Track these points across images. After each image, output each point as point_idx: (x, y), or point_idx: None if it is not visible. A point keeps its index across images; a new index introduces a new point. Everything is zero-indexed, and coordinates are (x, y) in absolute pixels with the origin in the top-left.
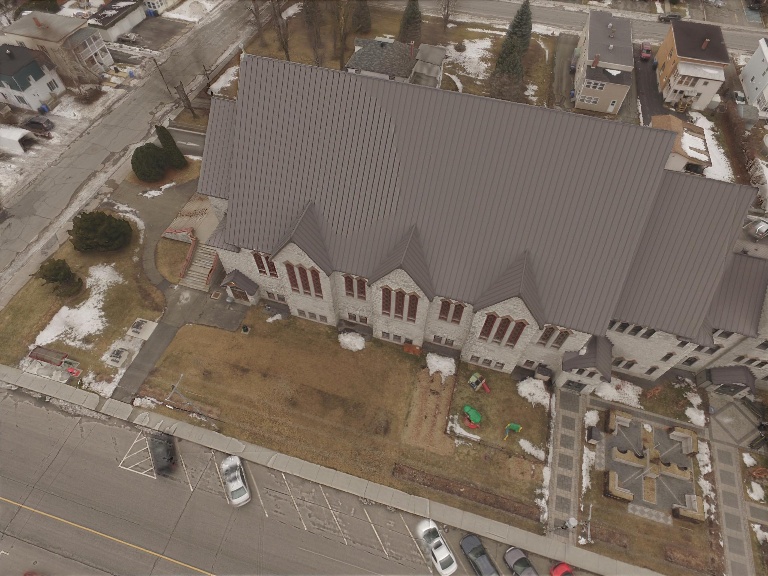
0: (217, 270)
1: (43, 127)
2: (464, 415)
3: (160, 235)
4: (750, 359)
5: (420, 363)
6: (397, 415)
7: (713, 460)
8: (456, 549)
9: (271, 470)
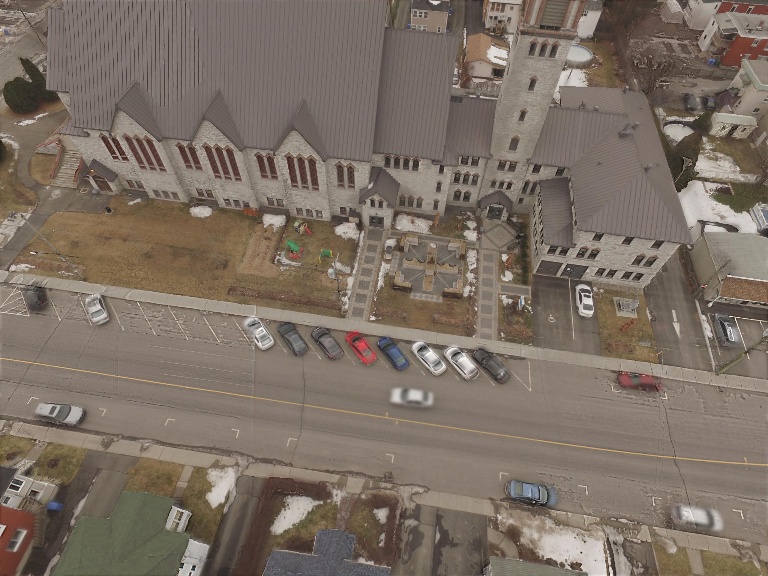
0: (84, 171)
1: None
2: (289, 250)
3: (33, 152)
4: (500, 183)
5: (257, 221)
6: (235, 256)
7: (479, 260)
8: (275, 333)
9: (128, 301)
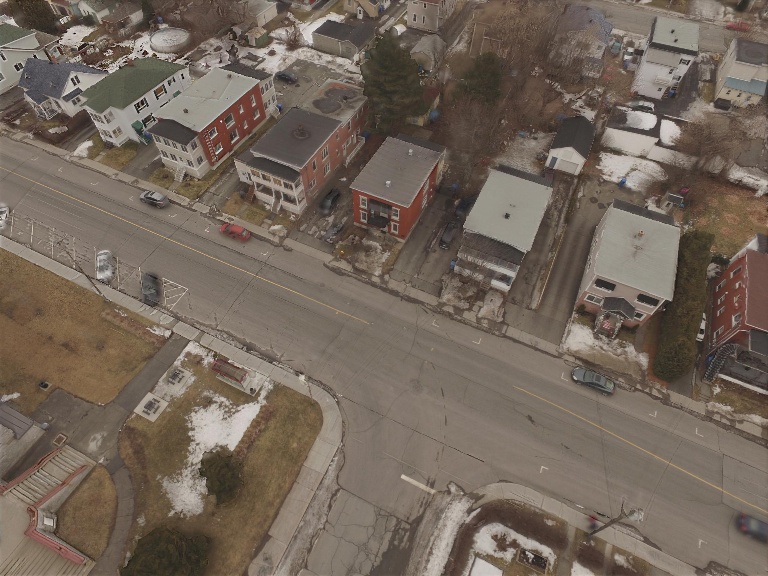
0: None
1: None
2: None
3: (98, 568)
4: None
5: None
6: None
7: None
8: None
9: None
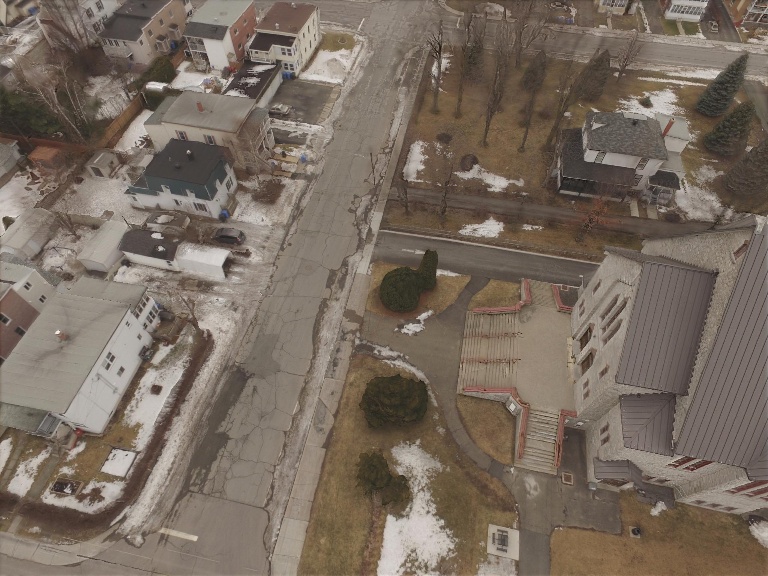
0: None
1: (236, 241)
2: None
3: (453, 391)
4: None
5: None
6: None
7: None
8: None
9: None
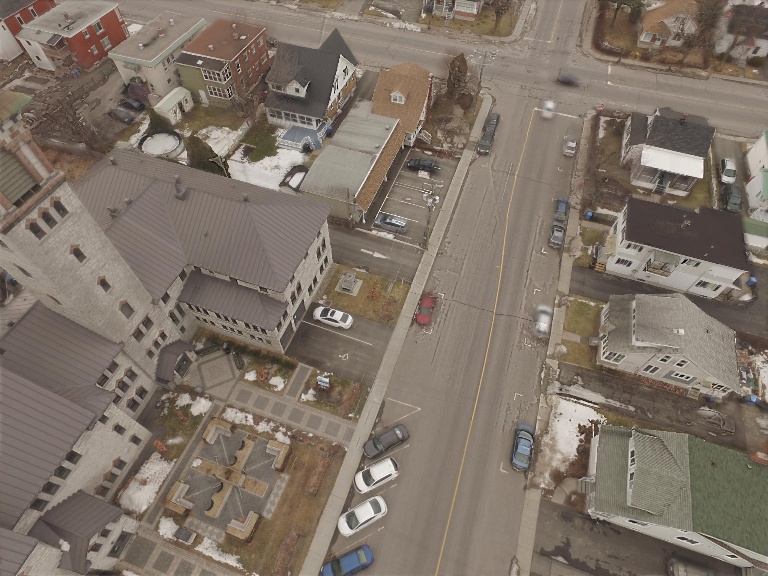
0: None
1: None
2: None
3: None
4: (153, 346)
5: None
6: None
7: (243, 409)
8: None
9: None
